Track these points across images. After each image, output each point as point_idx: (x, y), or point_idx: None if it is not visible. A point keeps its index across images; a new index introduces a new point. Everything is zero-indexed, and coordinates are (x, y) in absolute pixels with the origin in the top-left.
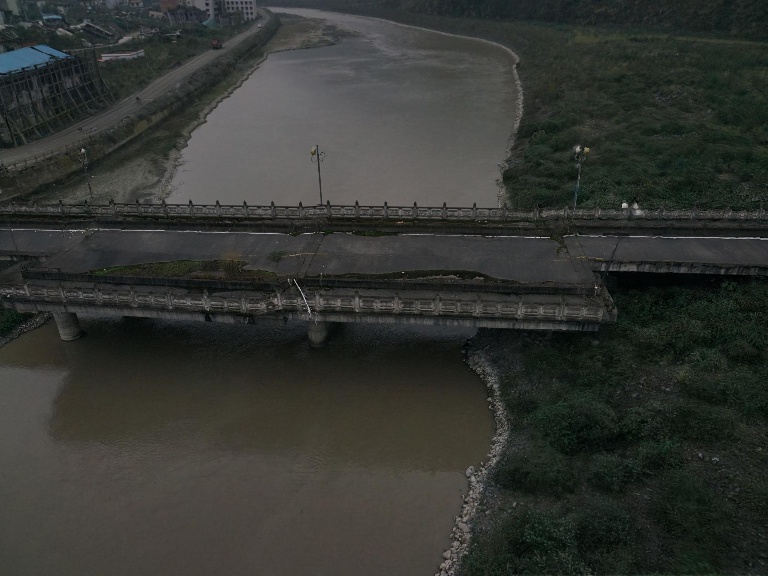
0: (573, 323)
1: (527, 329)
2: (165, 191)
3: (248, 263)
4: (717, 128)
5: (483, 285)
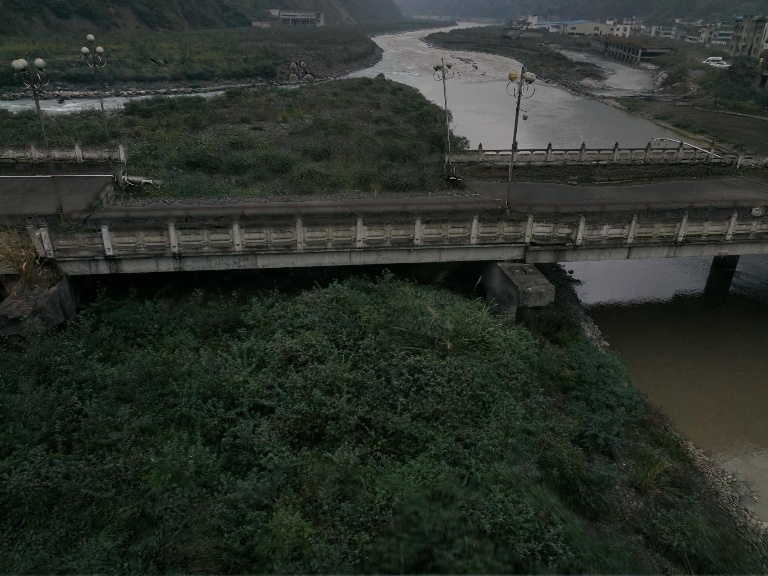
0: None
1: None
2: None
3: None
4: None
5: (559, 169)
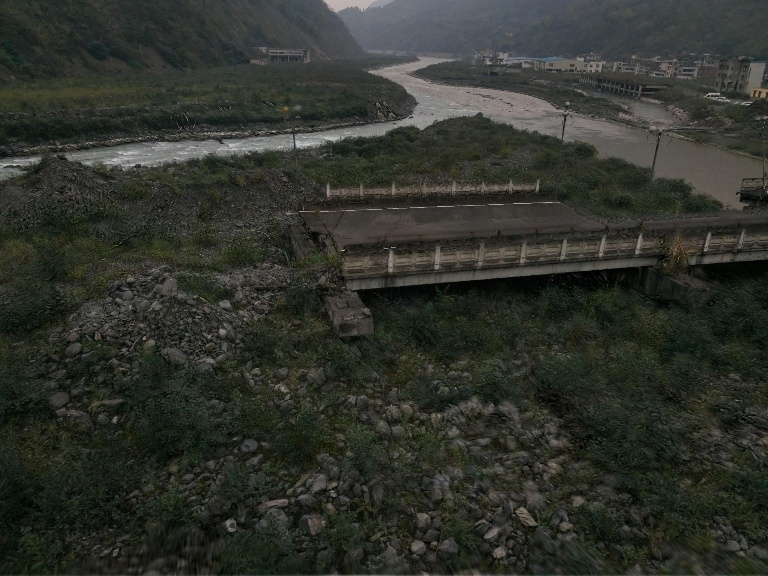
0: None
1: None
2: None
3: None
4: None
5: None
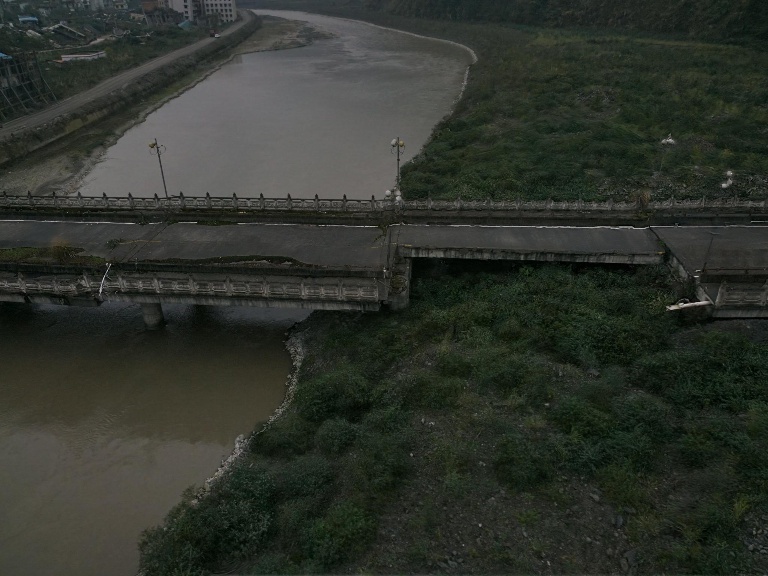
0: (354, 303)
1: (341, 312)
2: (74, 186)
3: (84, 250)
4: (616, 126)
5: (283, 269)
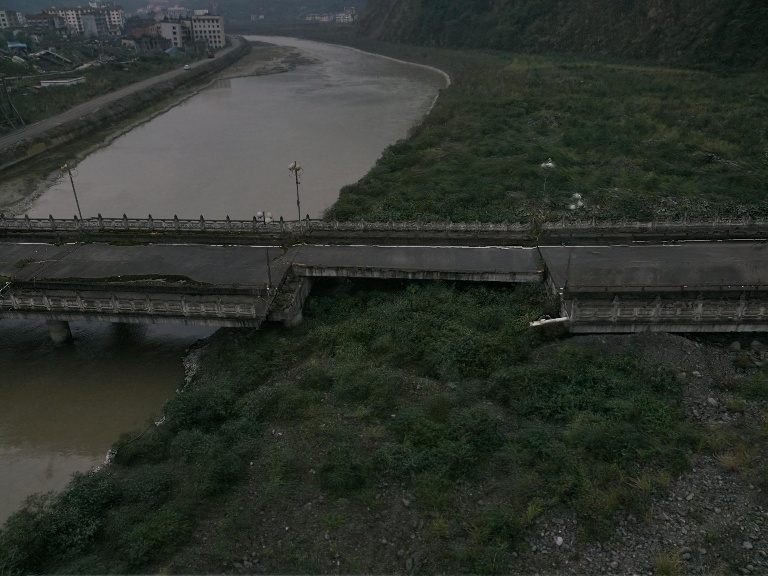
0: (233, 320)
1: (237, 329)
2: (23, 208)
3: None
4: (555, 150)
5: (172, 287)
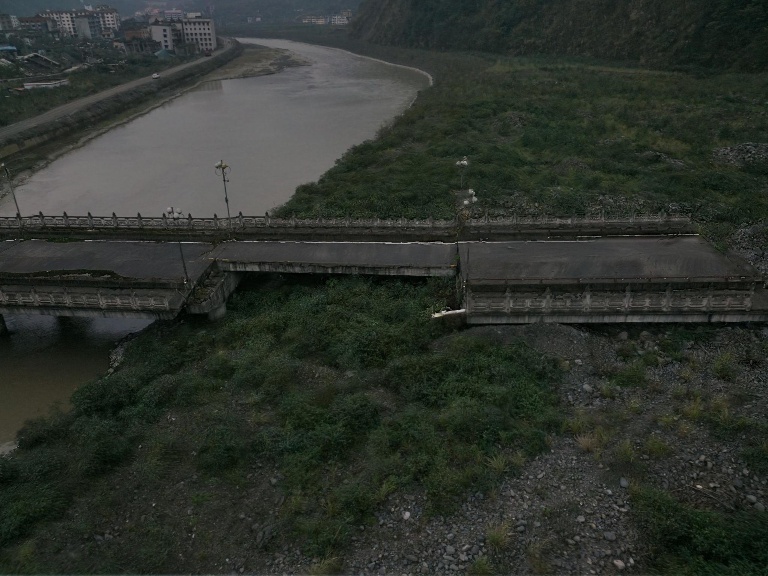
0: (148, 312)
1: (163, 322)
2: None
3: None
4: (511, 150)
5: (94, 281)
